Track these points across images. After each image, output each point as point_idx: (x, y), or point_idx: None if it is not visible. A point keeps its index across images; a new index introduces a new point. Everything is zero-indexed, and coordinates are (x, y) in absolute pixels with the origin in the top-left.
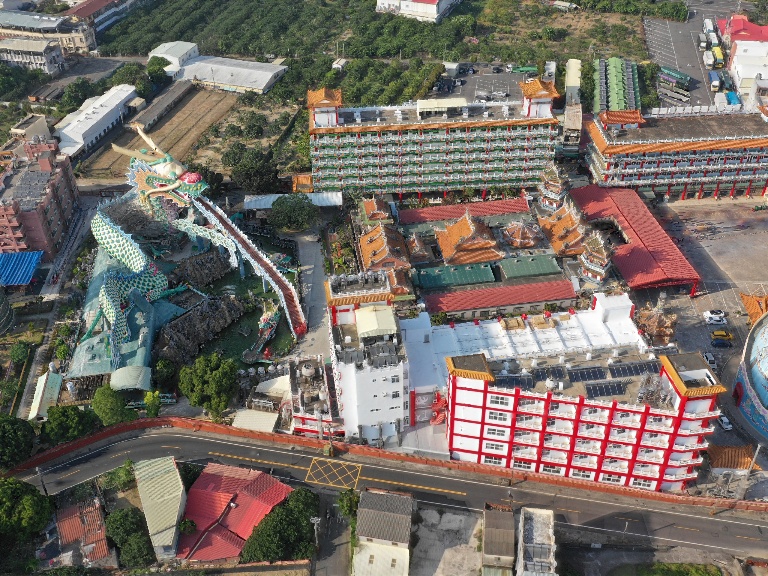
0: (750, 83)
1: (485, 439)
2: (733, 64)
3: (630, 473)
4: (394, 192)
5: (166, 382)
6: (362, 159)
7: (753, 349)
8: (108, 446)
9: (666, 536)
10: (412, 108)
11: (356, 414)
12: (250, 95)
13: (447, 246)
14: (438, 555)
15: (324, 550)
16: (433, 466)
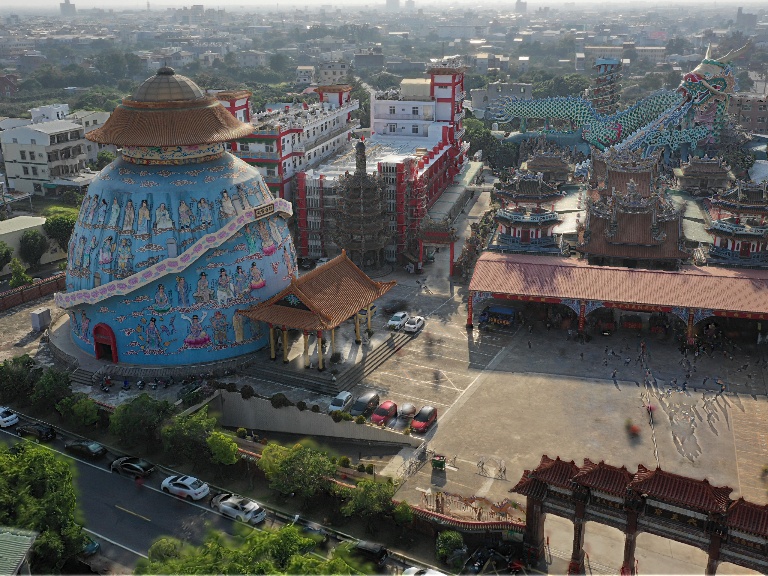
0: None
1: None
2: None
3: None
4: None
5: None
6: None
7: None
8: None
9: None
10: None
11: None
12: None
13: None
14: None
15: None
16: None
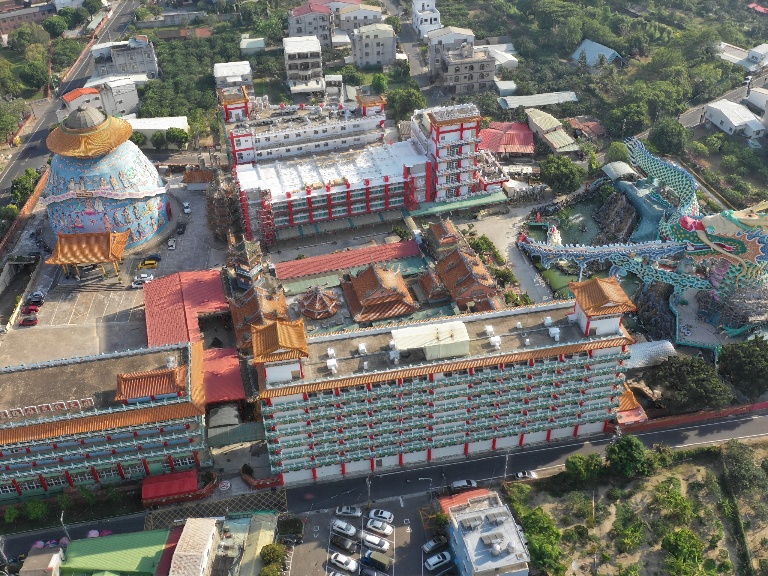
0: None
1: None
2: None
3: None
4: None
5: None
6: None
7: None
8: None
9: None
10: None
11: None
12: None
13: (402, 287)
14: None
15: None
16: None
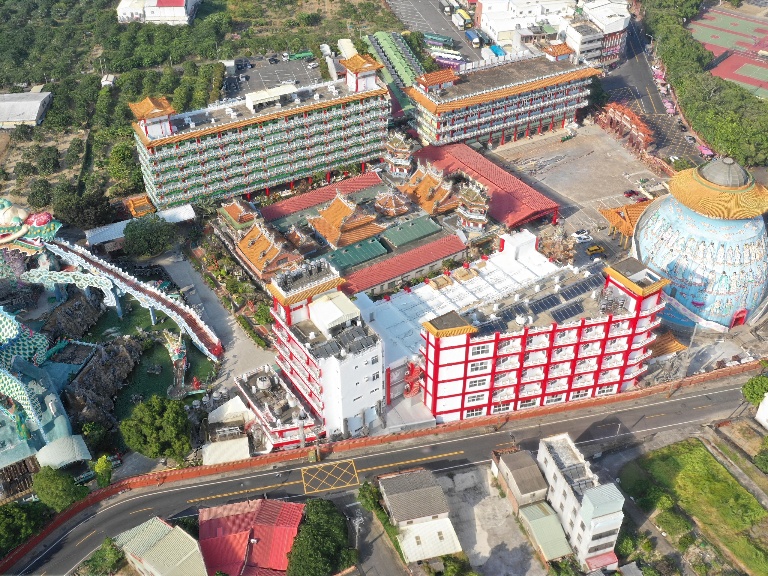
0: (505, 35)
1: (467, 393)
2: (483, 21)
3: (596, 384)
4: (242, 193)
5: (98, 446)
6: (206, 165)
7: (641, 250)
8: (66, 535)
9: (644, 428)
10: (240, 104)
11: (340, 408)
12: (23, 129)
13: (328, 231)
14: (470, 515)
15: (362, 551)
16: (420, 437)
